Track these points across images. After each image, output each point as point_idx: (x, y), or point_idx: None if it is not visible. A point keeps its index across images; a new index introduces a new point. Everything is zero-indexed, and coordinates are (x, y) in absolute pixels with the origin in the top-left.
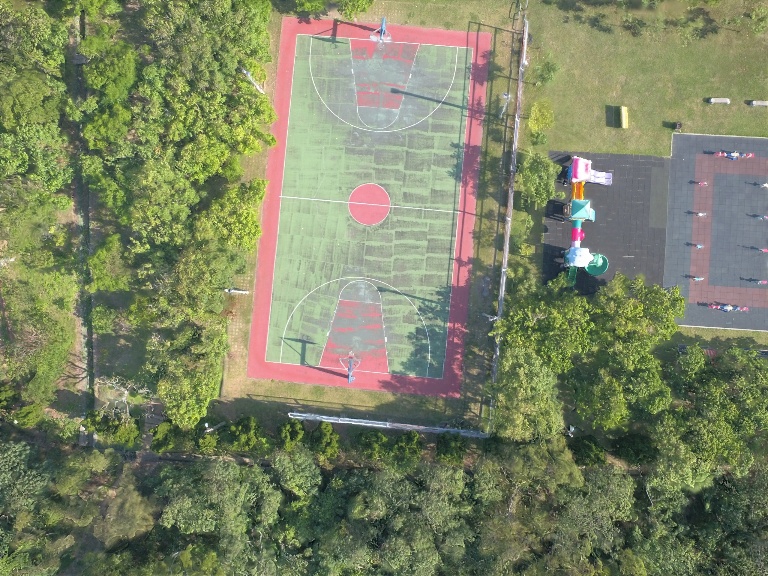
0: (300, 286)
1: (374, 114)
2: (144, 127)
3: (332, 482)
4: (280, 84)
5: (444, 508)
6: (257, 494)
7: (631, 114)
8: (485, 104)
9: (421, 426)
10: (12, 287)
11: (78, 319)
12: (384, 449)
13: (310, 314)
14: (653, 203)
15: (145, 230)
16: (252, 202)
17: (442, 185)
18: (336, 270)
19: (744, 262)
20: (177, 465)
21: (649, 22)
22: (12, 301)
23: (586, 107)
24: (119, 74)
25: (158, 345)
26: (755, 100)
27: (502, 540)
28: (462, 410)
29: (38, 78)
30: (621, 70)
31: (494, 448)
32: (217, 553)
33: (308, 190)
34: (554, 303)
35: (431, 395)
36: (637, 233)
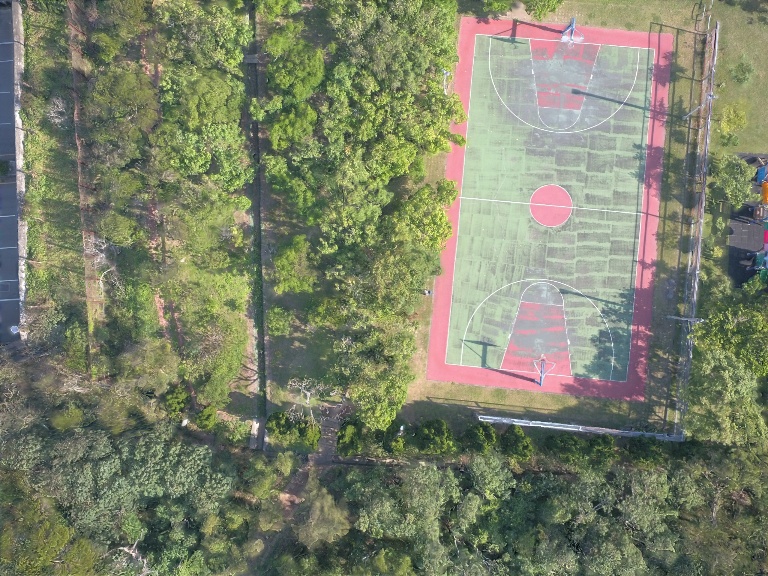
0: (481, 288)
1: (555, 115)
2: (332, 127)
3: (521, 486)
4: (459, 84)
5: (650, 512)
6: (445, 498)
7: None
8: (667, 105)
9: (615, 429)
10: (182, 288)
11: (250, 321)
12: (578, 453)
13: (491, 316)
14: None
15: (334, 231)
16: (446, 203)
17: (625, 186)
18: (517, 272)
19: None
20: (352, 468)
21: None
22: (188, 302)
23: None
24: (308, 73)
25: (347, 347)
26: None
27: (705, 545)
28: (646, 413)
29: (218, 77)
30: None
31: (695, 452)
32: (411, 558)
33: (488, 191)
34: (753, 306)
35: (615, 398)
36: None
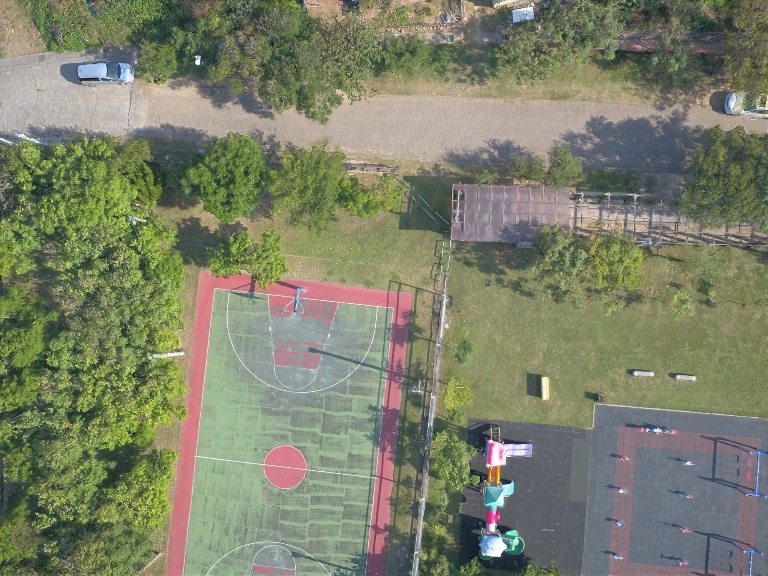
0: (214, 549)
1: (291, 374)
2: (52, 397)
3: None
4: (196, 340)
5: None
6: None
7: (553, 383)
8: (405, 366)
9: None
10: None
11: None
12: None
13: None
14: (574, 476)
15: (51, 505)
16: (159, 482)
17: (359, 449)
18: (250, 534)
19: (665, 540)
20: None
21: None
22: None
23: (507, 374)
24: (26, 344)
25: None
26: (679, 374)
27: None
28: None
29: None
30: (543, 337)
31: None
32: None
33: (223, 450)
34: None
35: None
36: (557, 506)
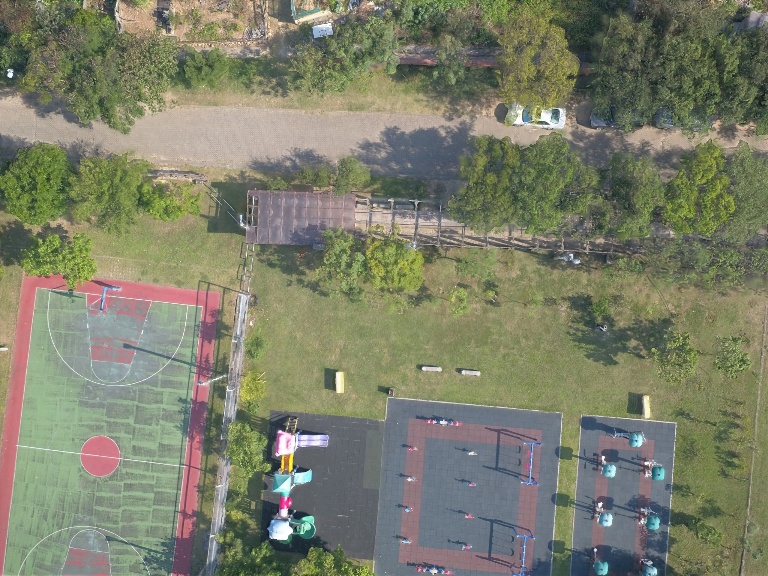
0: (33, 533)
1: (107, 368)
2: None
3: None
4: (19, 336)
5: None
6: None
7: (348, 378)
8: (212, 362)
9: None
10: None
11: None
12: None
13: (42, 560)
14: (367, 465)
15: None
16: None
17: (169, 439)
18: (67, 519)
19: (452, 525)
20: None
21: (368, 289)
22: None
23: (306, 369)
24: None
25: None
26: (465, 369)
27: None
28: None
29: None
30: (340, 334)
31: None
32: None
33: (43, 440)
34: (253, 575)
35: None
36: (351, 493)
